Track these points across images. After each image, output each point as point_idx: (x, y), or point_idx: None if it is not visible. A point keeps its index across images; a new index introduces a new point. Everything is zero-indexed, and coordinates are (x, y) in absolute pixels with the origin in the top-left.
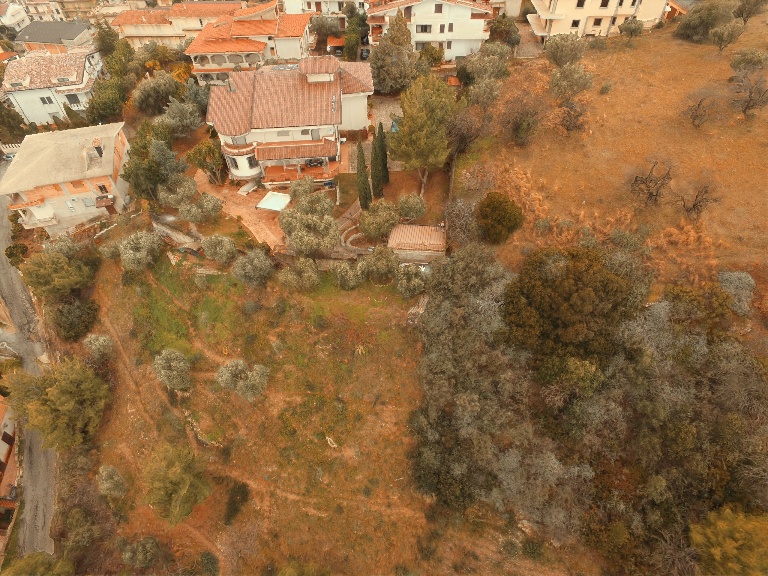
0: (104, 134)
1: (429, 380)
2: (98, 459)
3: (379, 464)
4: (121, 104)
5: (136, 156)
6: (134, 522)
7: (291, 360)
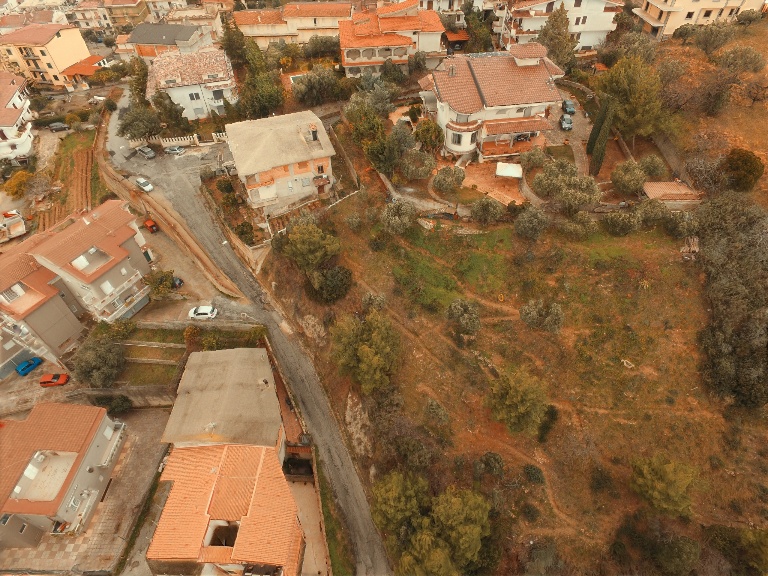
0: (309, 120)
1: (723, 302)
2: None
3: (675, 378)
4: (283, 96)
5: (359, 137)
6: (458, 445)
7: (575, 299)
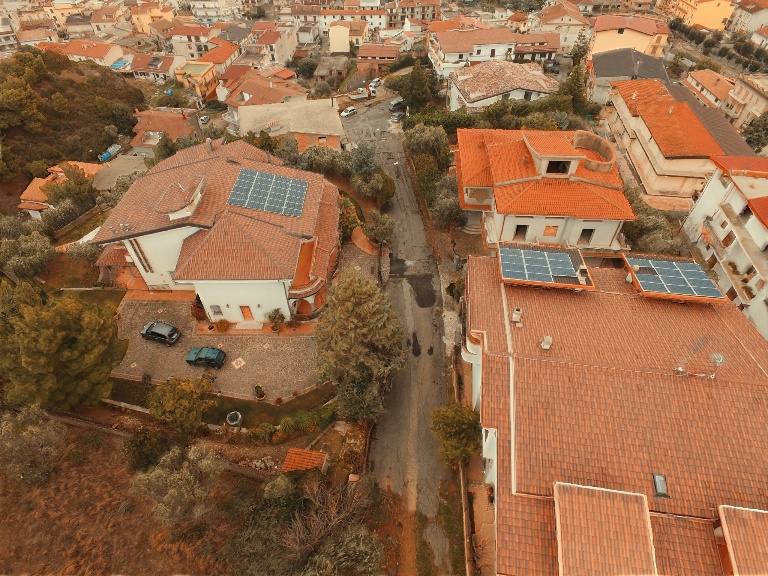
0: (299, 126)
1: None
2: None
3: None
4: None
5: None
6: None
7: None
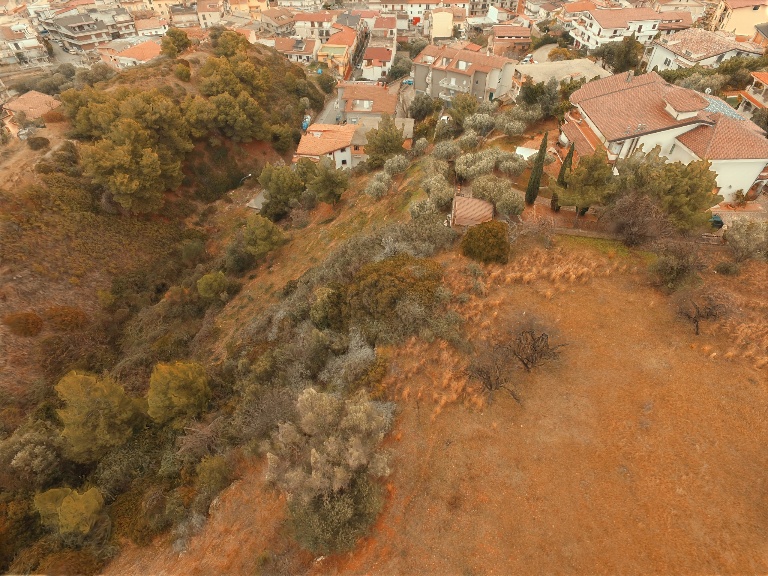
0: None
1: None
2: (362, 174)
3: None
4: None
5: None
6: None
7: None
